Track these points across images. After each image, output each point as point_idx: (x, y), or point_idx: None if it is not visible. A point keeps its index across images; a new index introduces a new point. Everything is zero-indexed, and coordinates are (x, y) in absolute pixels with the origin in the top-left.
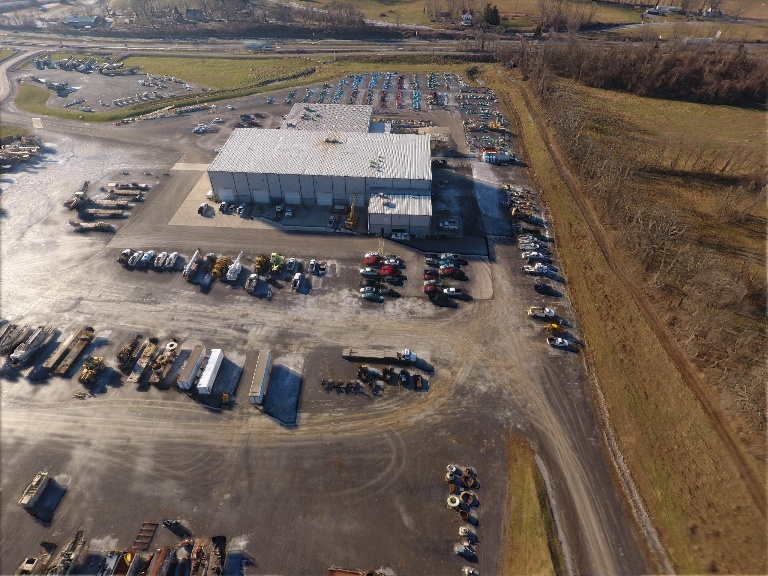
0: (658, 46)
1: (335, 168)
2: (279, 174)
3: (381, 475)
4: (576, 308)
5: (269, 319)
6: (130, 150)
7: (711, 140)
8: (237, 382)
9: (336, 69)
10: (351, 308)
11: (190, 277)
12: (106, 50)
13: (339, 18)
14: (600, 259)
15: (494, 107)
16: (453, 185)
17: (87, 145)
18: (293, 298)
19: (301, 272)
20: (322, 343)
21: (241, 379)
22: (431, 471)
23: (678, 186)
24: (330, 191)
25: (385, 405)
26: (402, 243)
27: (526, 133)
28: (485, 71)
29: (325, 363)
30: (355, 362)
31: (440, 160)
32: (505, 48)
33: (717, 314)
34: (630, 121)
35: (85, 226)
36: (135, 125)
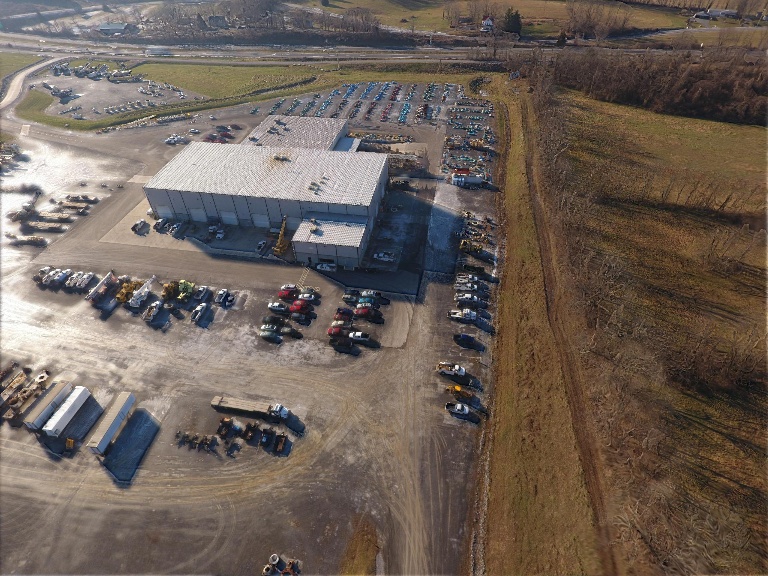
0: (690, 55)
1: (271, 189)
2: (212, 194)
3: (194, 558)
4: (496, 366)
5: (154, 354)
6: (98, 160)
7: (726, 167)
8: (91, 425)
9: (336, 78)
10: (244, 348)
11: (94, 301)
12: (125, 57)
13: (354, 24)
14: (540, 308)
15: (486, 122)
16: (408, 210)
17: (61, 154)
18: (188, 331)
19: (208, 302)
20: (197, 387)
21: (97, 422)
22: (251, 560)
23: (665, 222)
24: (266, 213)
25: (234, 469)
26: (327, 275)
27: (511, 152)
28: (491, 81)
29: (190, 411)
30: (222, 413)
31: (402, 181)
32: (515, 57)
33: (629, 401)
34: (634, 142)
35: (19, 239)
36: (113, 134)
